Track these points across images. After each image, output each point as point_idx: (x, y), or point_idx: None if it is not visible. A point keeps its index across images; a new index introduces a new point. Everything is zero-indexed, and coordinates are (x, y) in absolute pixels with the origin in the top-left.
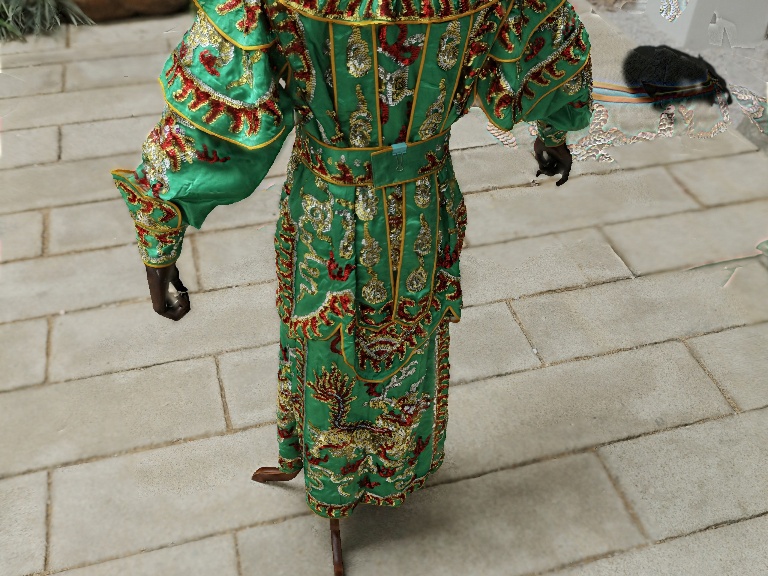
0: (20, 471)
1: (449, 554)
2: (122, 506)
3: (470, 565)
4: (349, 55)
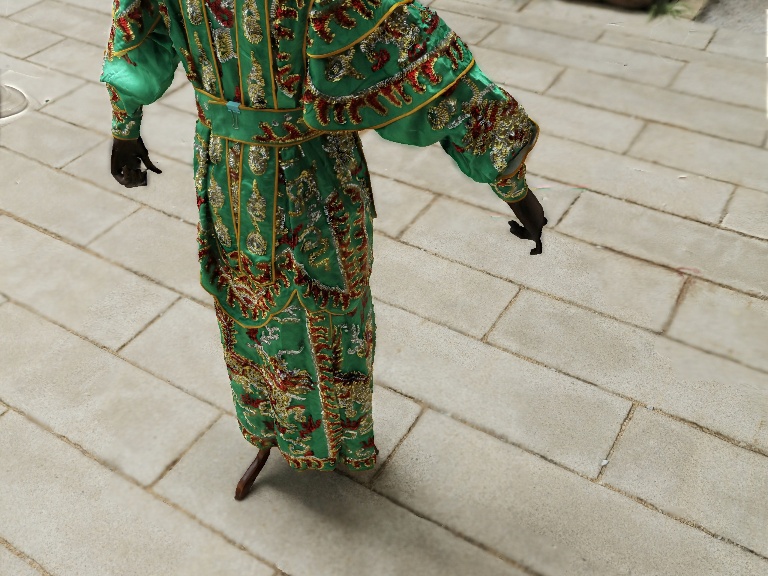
0: (169, 286)
1: (326, 548)
2: (189, 346)
3: (329, 569)
4: (187, 1)
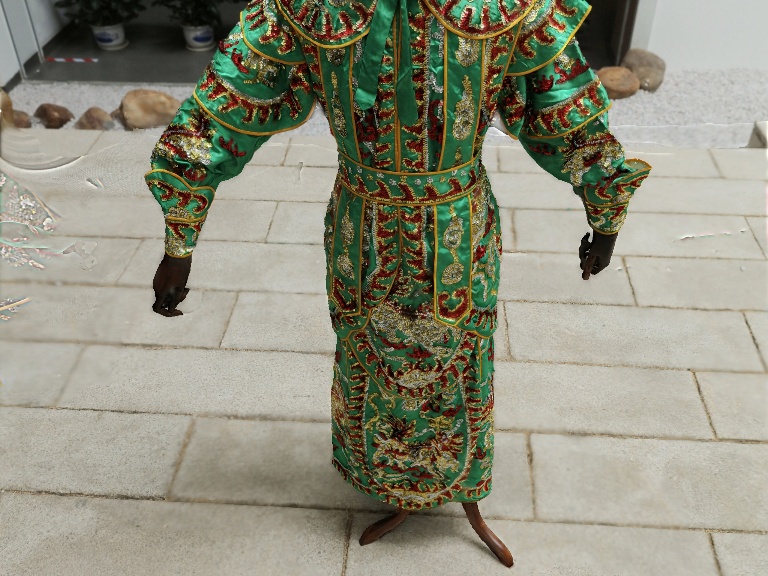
0: None
1: None
2: (648, 573)
3: None
4: None
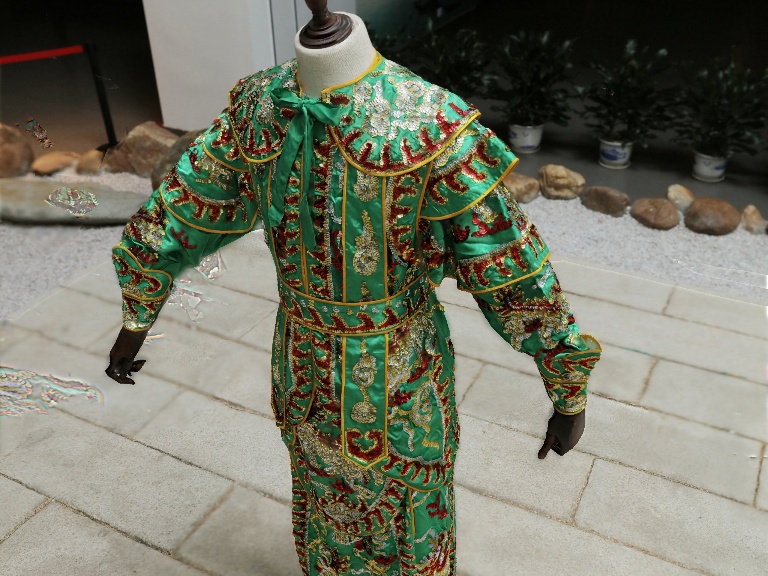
0: None
1: None
2: None
3: None
4: None
